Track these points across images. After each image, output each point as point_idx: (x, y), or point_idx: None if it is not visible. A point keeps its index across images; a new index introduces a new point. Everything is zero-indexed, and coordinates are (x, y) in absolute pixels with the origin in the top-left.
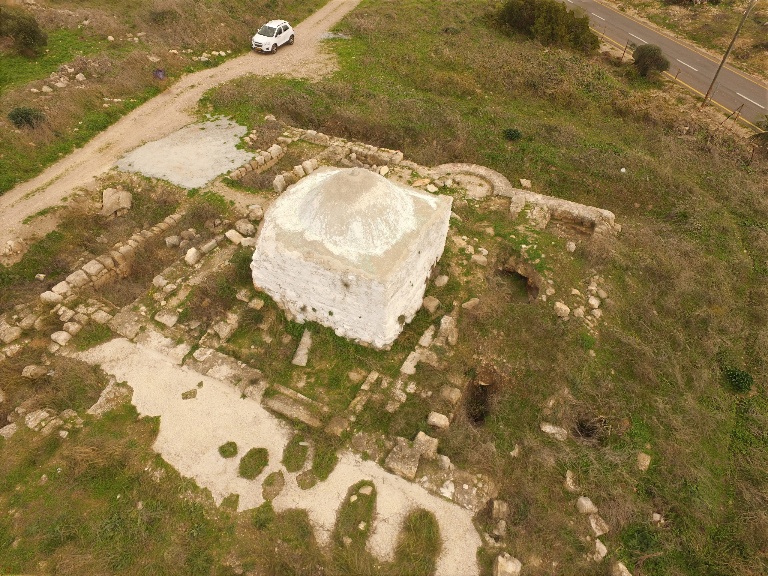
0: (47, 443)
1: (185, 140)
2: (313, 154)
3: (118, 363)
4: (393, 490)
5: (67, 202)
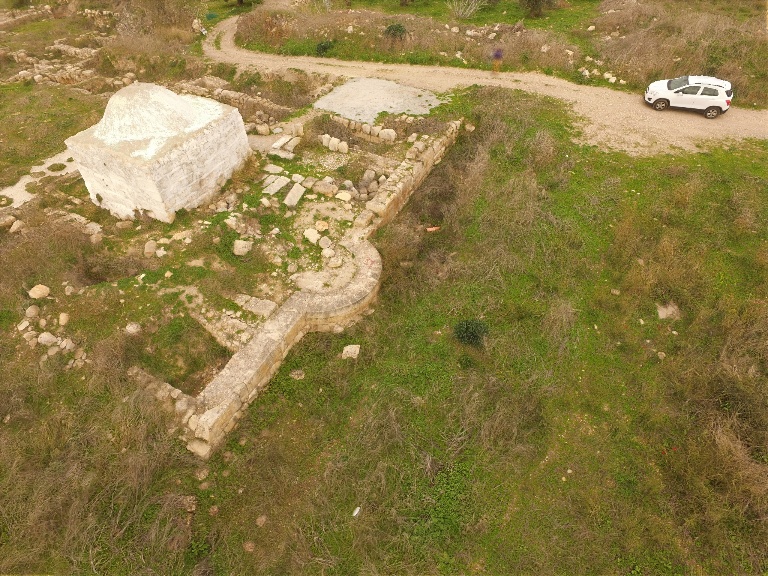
0: None
1: (397, 92)
2: (389, 157)
3: None
4: None
5: (311, 75)
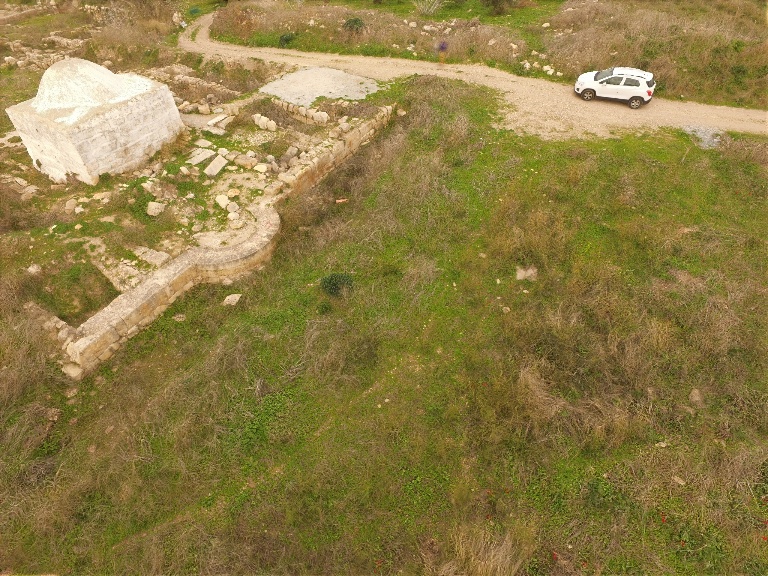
0: None
1: (341, 80)
2: (317, 136)
3: None
4: None
5: (269, 64)
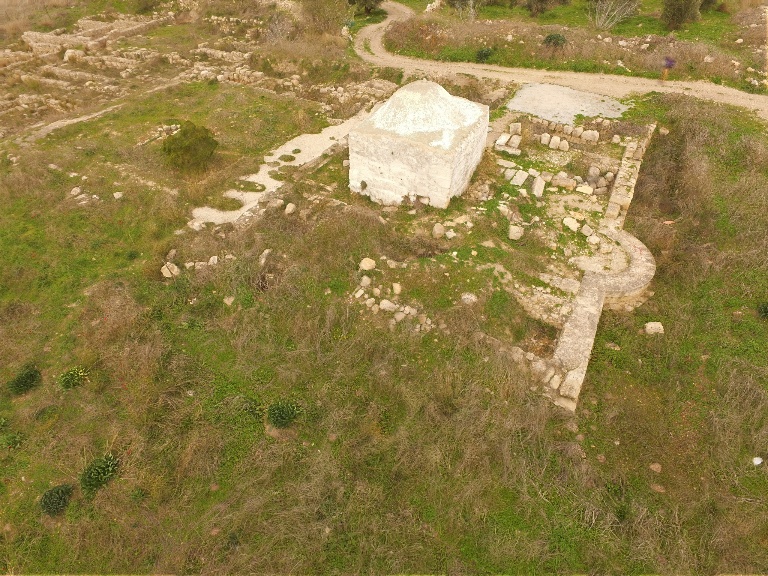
0: (312, 111)
1: (579, 97)
2: None
3: (356, 119)
4: (256, 197)
5: (482, 79)
